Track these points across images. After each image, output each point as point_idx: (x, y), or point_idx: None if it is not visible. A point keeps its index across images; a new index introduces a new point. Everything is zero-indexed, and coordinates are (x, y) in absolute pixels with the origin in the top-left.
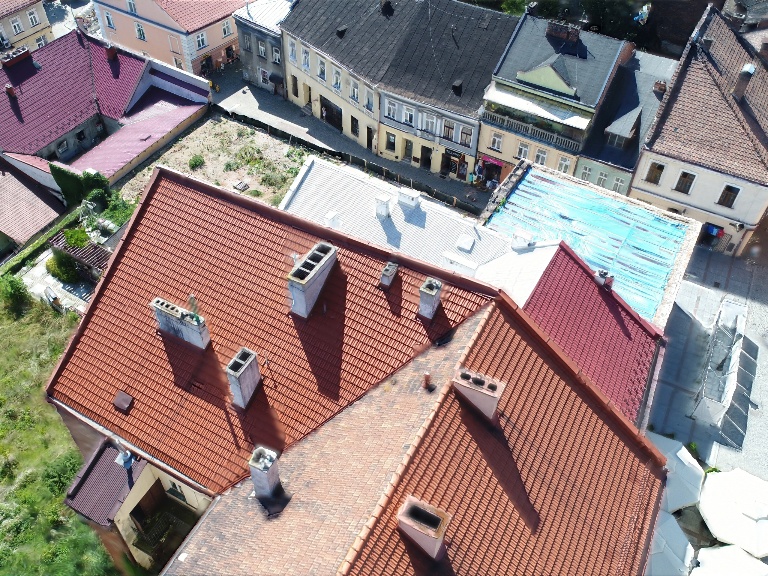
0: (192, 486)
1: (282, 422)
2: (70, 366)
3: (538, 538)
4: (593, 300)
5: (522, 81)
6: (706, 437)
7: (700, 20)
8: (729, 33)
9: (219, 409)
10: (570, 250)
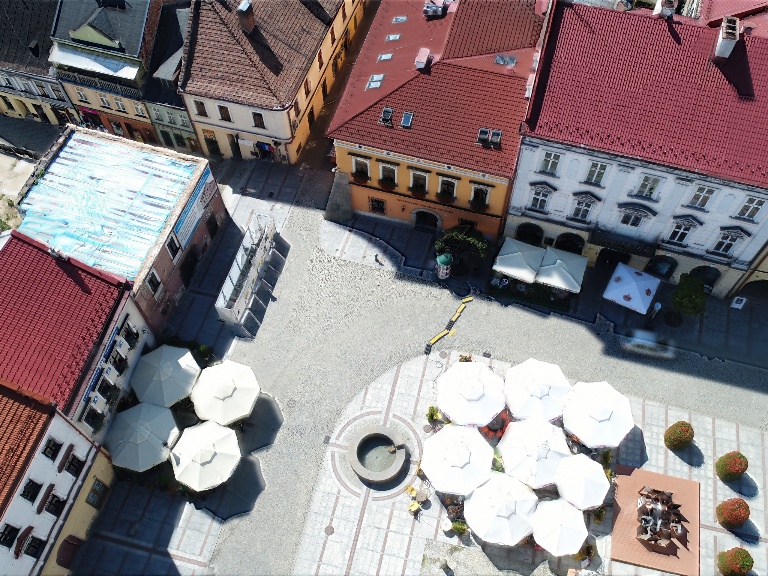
0: None
1: None
2: None
3: None
4: (49, 272)
5: (76, 40)
6: (230, 334)
7: None
8: None
9: None
10: (22, 236)
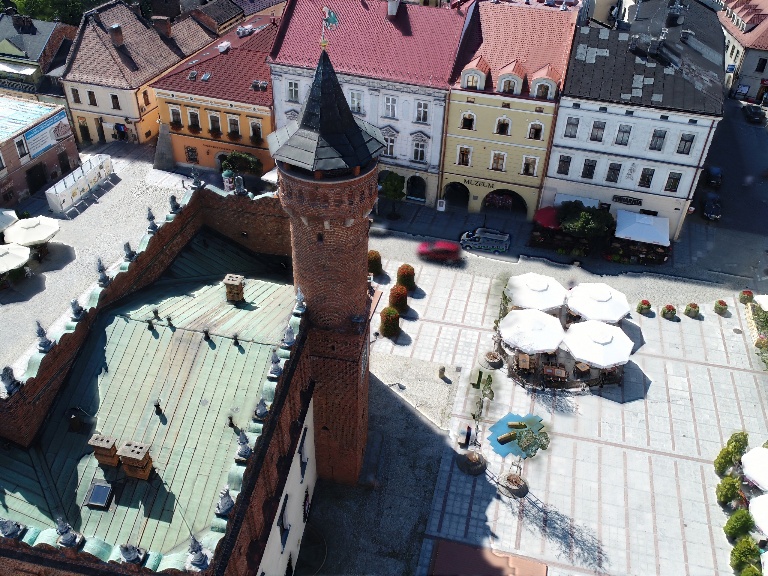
0: None
1: None
2: None
3: None
4: None
5: None
6: (54, 217)
7: None
8: (130, 14)
9: None
10: None
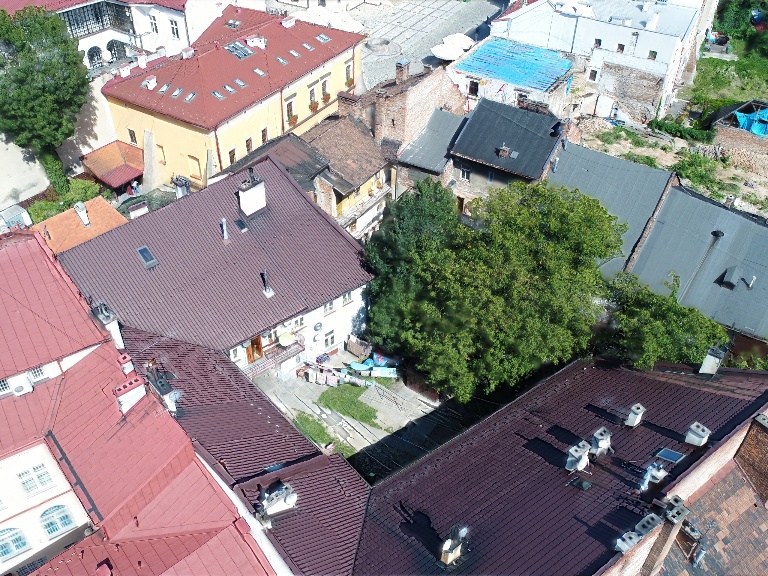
0: None
1: None
2: None
3: None
4: None
5: None
6: None
7: (426, 77)
8: None
9: None
10: None
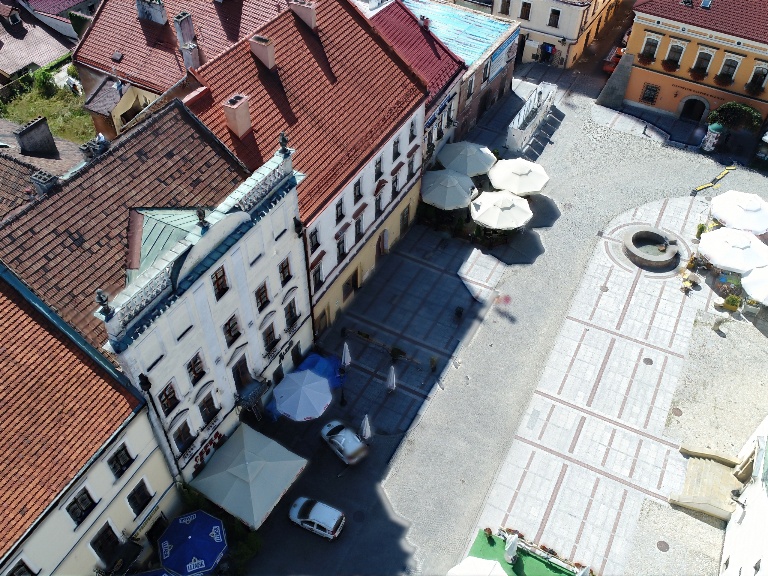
0: (155, 92)
1: (206, 57)
2: (87, 43)
3: (335, 87)
4: (415, 33)
5: None
6: (513, 156)
7: None
8: None
9: (172, 54)
10: None
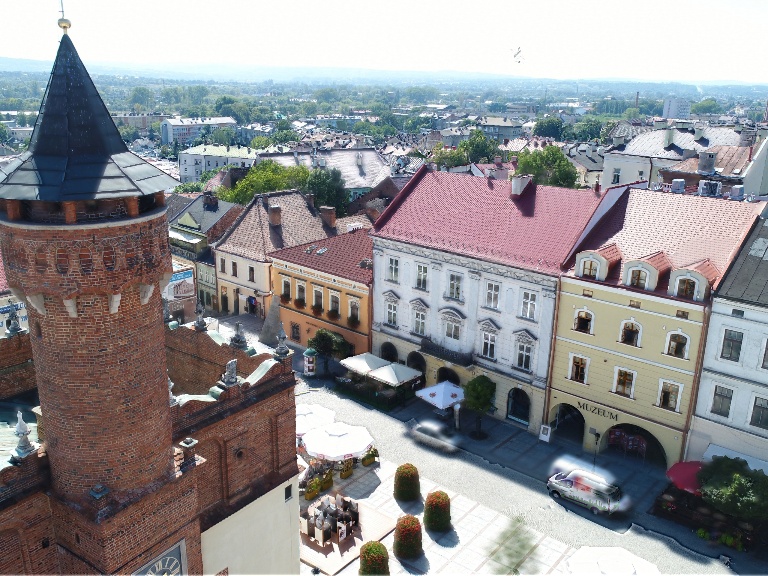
0: None
1: None
2: None
3: None
4: None
5: (180, 224)
6: None
7: None
8: (302, 203)
9: None
10: None
